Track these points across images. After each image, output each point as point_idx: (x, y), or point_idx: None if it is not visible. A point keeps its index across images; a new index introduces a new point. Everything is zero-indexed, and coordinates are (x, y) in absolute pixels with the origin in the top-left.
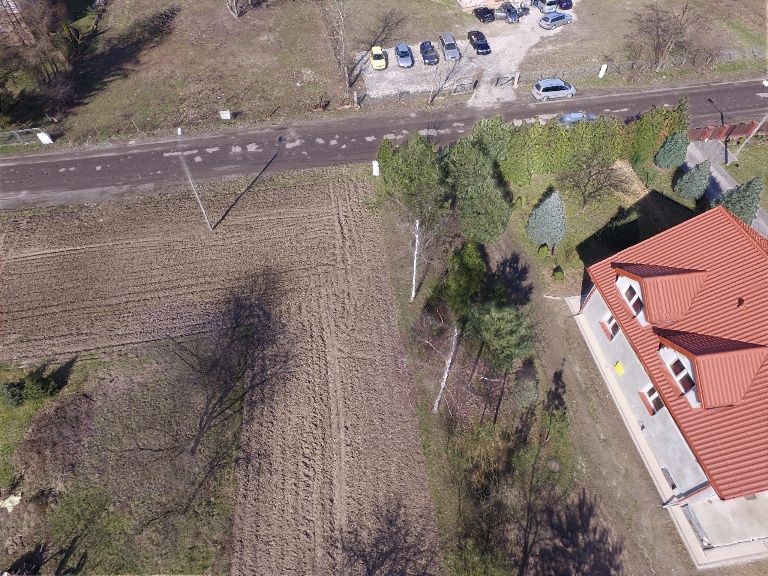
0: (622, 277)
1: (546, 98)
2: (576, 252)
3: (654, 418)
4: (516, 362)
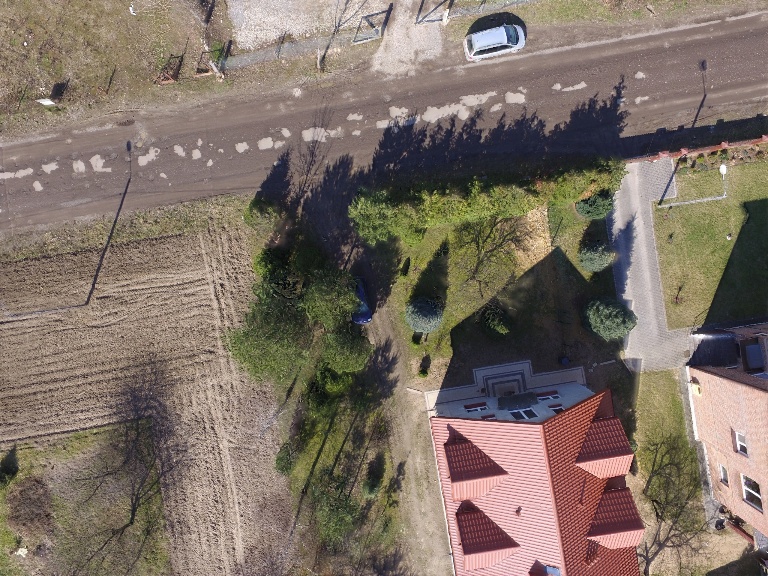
0: None
1: (480, 58)
2: (449, 337)
3: None
4: (371, 454)
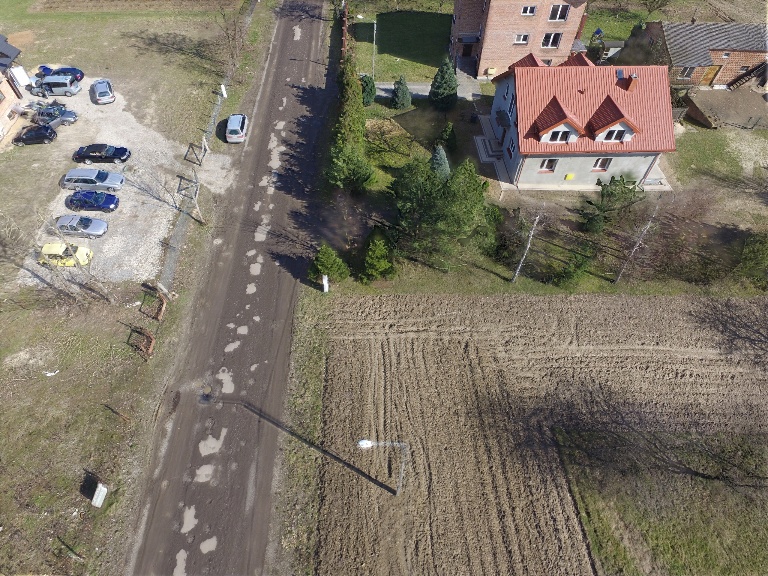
0: (548, 133)
1: None
2: None
3: (608, 170)
4: (563, 228)
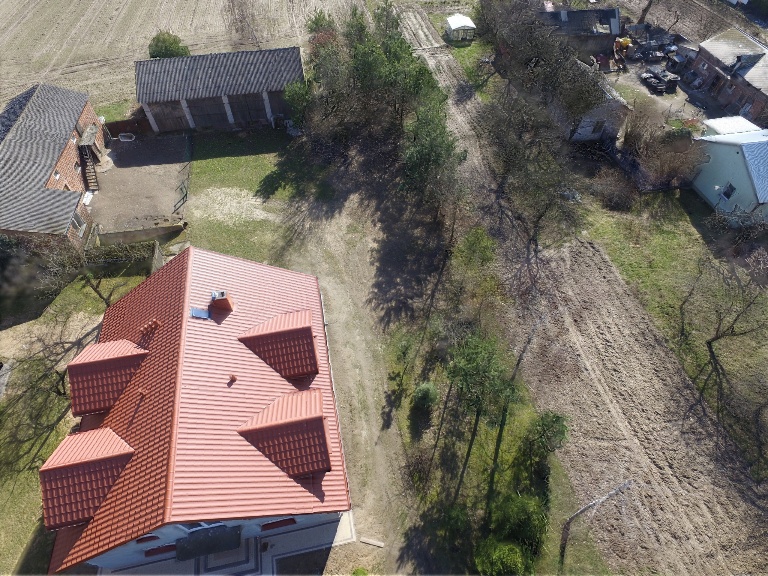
0: None
1: None
2: None
3: None
4: (430, 439)
